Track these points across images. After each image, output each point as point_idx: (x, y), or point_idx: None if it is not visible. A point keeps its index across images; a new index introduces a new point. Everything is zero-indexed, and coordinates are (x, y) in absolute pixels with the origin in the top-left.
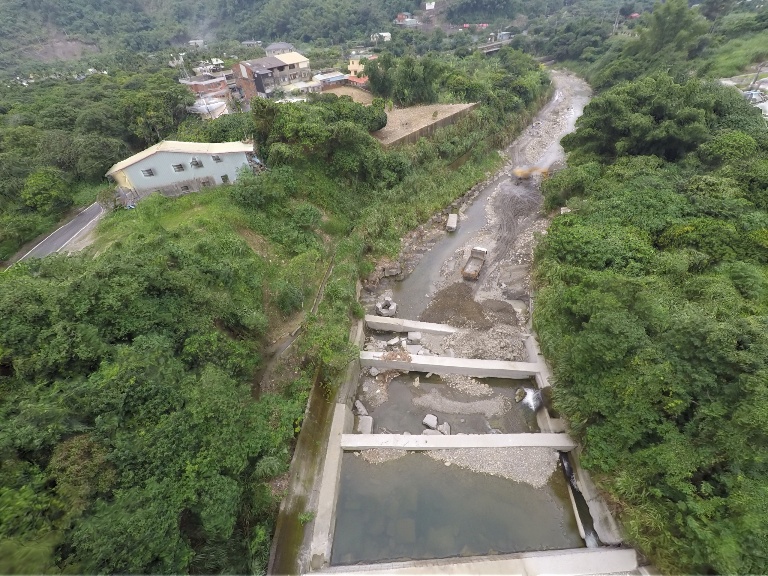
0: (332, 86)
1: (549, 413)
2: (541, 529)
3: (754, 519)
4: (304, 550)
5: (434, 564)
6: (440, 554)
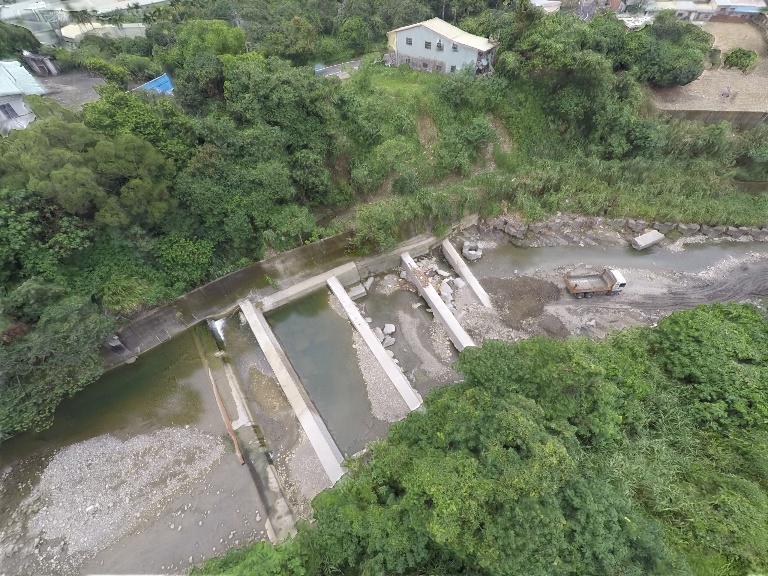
0: (731, 19)
1: None
2: (344, 427)
3: (354, 511)
4: (258, 292)
5: (281, 358)
6: (297, 368)
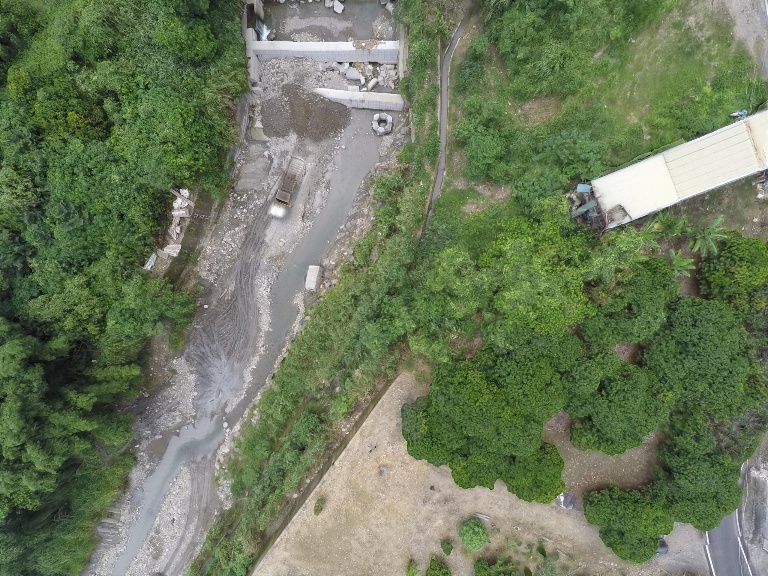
0: None
1: (254, 7)
2: None
3: None
4: None
5: None
6: None
